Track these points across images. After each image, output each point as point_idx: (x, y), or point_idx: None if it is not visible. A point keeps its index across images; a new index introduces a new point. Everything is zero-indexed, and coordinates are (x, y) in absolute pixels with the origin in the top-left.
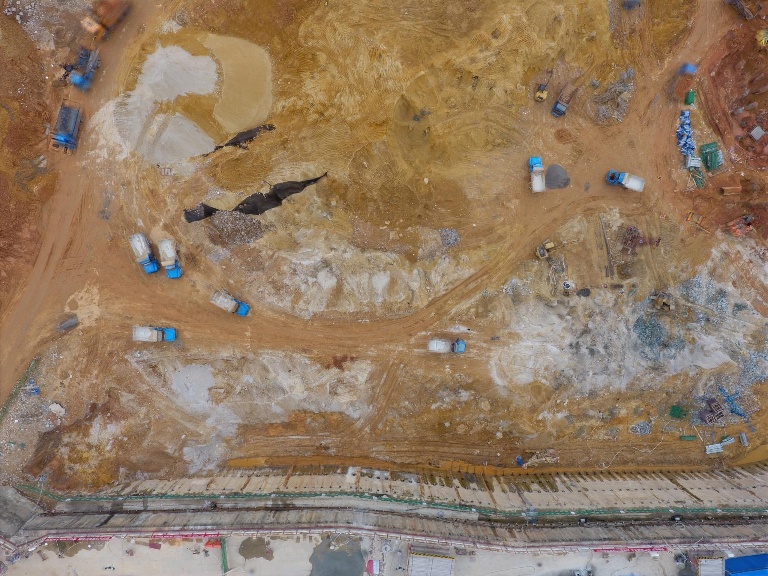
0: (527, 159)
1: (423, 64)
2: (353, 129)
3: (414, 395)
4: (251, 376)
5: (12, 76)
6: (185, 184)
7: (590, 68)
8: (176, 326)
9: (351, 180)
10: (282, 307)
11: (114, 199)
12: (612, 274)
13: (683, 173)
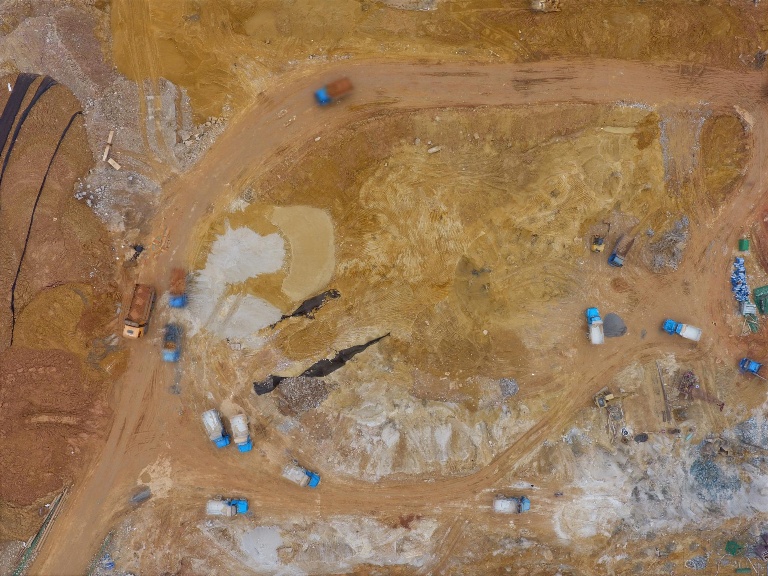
0: (584, 309)
1: (481, 218)
2: (415, 291)
3: (478, 547)
4: (318, 534)
5: (85, 261)
6: (254, 357)
7: (645, 217)
8: (247, 496)
9: (413, 338)
10: (351, 474)
11: (185, 374)
12: (669, 419)
13: (738, 318)
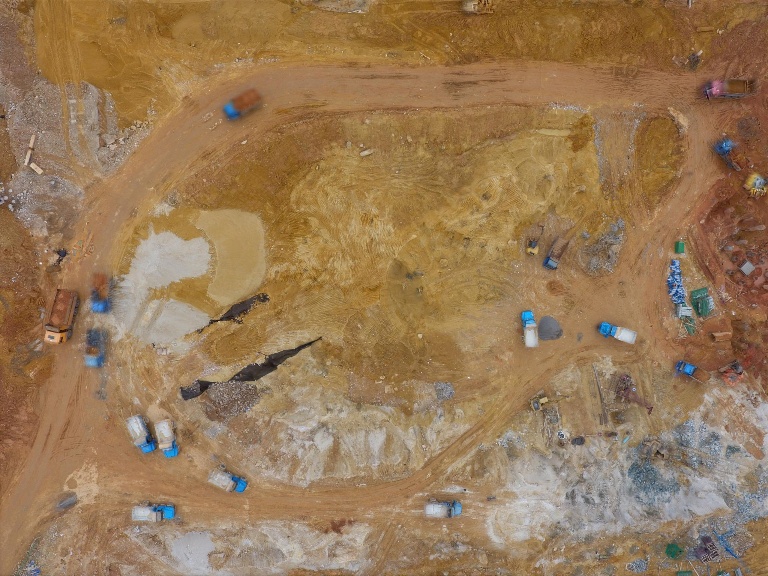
0: (520, 312)
1: (415, 221)
2: (346, 294)
3: (412, 551)
4: (250, 540)
5: (6, 266)
6: (181, 362)
7: (581, 219)
8: (175, 501)
9: (346, 342)
10: (280, 479)
11: (110, 379)
12: (606, 422)
13: (674, 321)
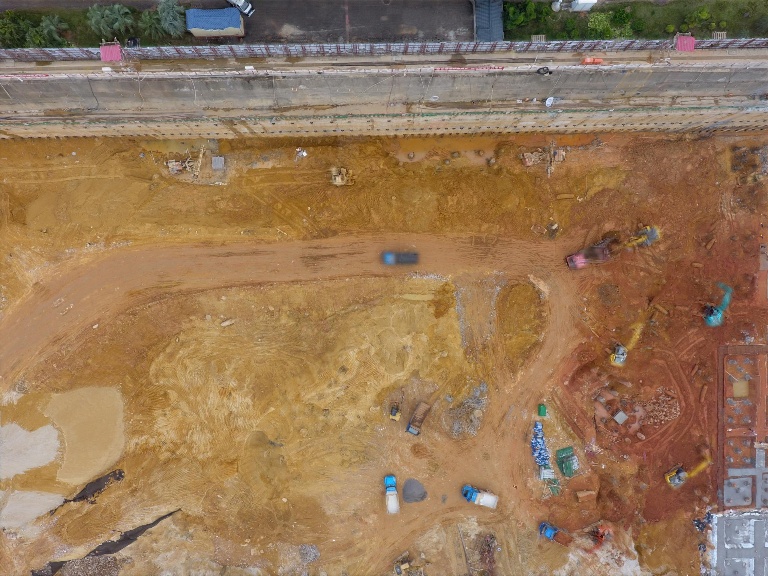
0: (384, 475)
1: (278, 388)
2: (204, 467)
3: None
4: None
5: None
6: (31, 546)
7: (445, 382)
8: None
9: (206, 512)
10: None
11: None
12: None
13: (539, 481)
